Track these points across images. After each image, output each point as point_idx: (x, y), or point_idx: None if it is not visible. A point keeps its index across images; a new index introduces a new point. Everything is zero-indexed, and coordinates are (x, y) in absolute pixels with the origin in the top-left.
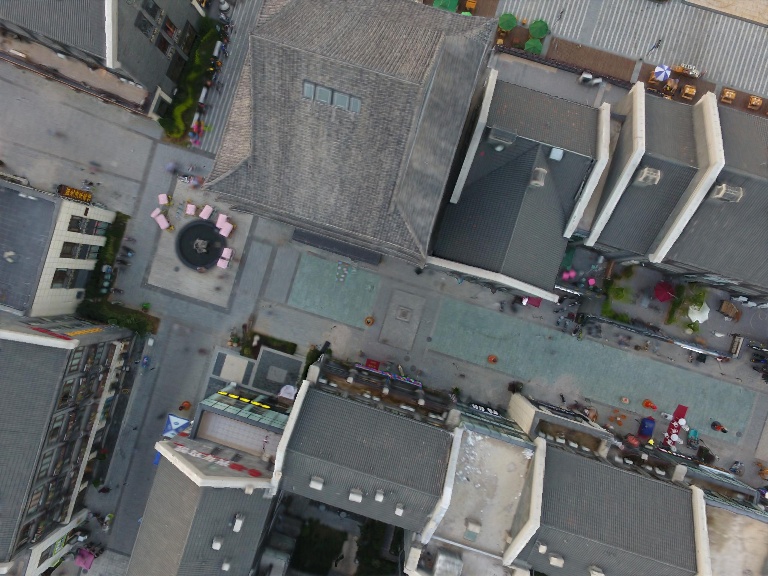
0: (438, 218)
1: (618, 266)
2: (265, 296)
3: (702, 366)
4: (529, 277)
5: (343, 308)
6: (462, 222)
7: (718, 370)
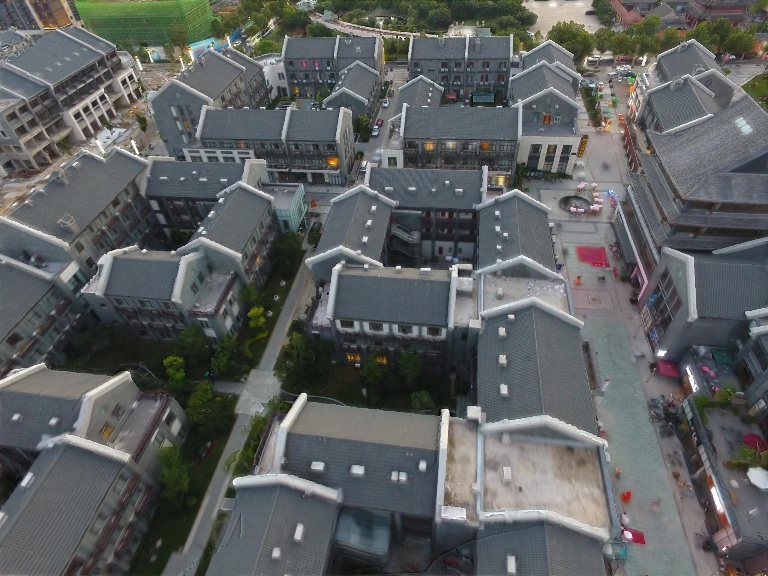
0: (695, 251)
1: (745, 412)
2: (562, 233)
3: (699, 552)
4: (700, 289)
5: (578, 268)
6: (705, 256)
7: (707, 574)
